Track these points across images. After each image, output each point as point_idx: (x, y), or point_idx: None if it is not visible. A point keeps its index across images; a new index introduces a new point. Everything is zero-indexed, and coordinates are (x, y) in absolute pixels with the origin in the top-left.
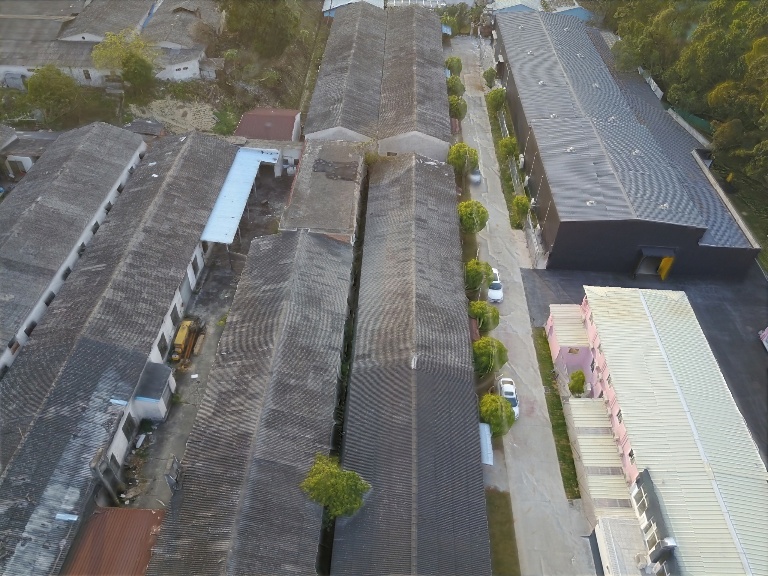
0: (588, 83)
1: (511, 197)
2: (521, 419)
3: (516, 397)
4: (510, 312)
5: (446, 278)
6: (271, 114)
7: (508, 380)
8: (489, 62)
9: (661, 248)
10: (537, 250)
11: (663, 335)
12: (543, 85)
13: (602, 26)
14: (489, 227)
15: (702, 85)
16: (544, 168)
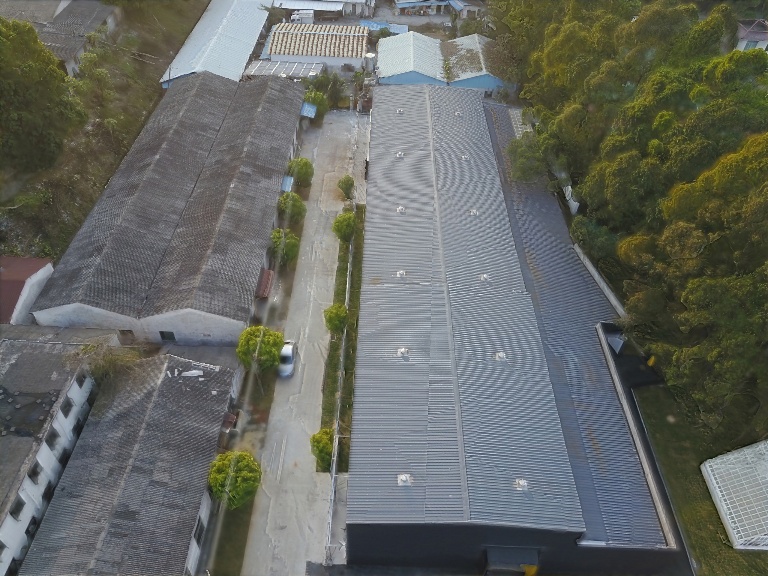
0: (465, 208)
1: (331, 402)
2: None
3: None
4: None
5: None
6: None
7: None
8: (364, 152)
9: (517, 549)
10: (327, 542)
11: None
12: (401, 213)
13: (514, 99)
14: (282, 469)
15: (615, 220)
16: (353, 392)
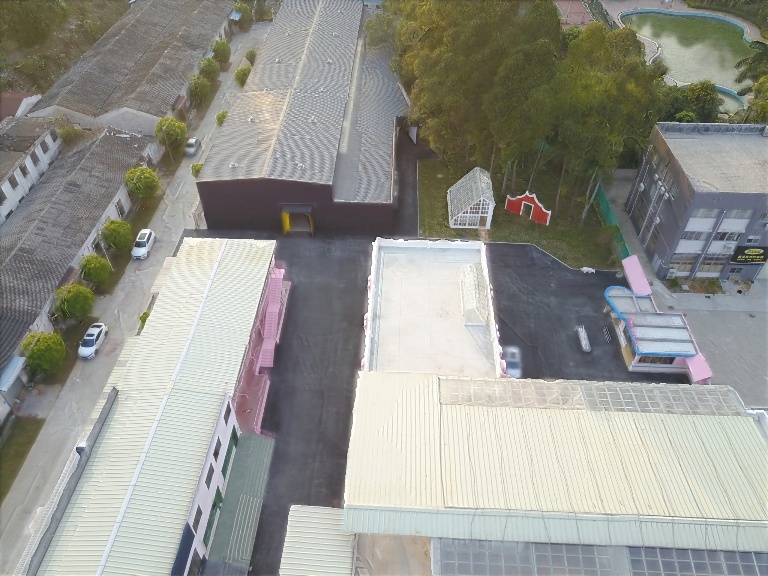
0: (323, 59)
1: None
2: (97, 358)
3: (96, 338)
4: (149, 267)
5: (66, 235)
6: (1, 97)
7: (99, 324)
8: None
9: (299, 205)
10: (193, 211)
11: (219, 277)
12: (278, 62)
13: None
14: (178, 194)
15: None
16: None
